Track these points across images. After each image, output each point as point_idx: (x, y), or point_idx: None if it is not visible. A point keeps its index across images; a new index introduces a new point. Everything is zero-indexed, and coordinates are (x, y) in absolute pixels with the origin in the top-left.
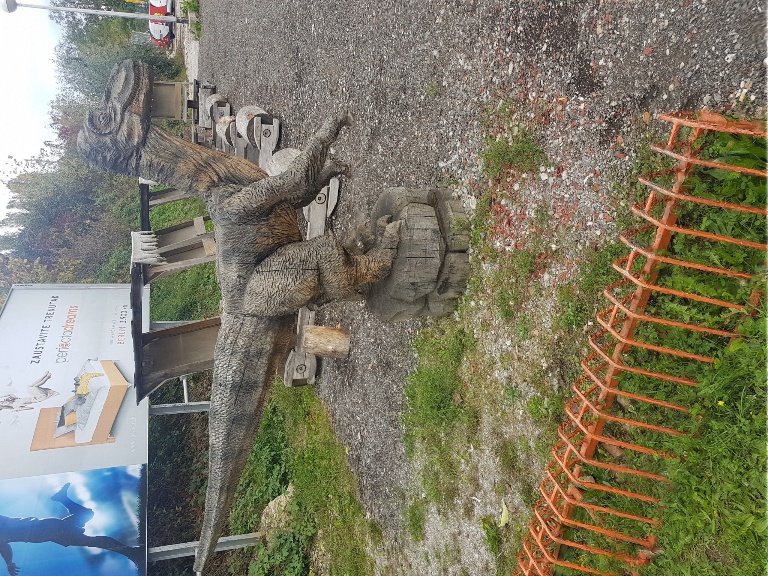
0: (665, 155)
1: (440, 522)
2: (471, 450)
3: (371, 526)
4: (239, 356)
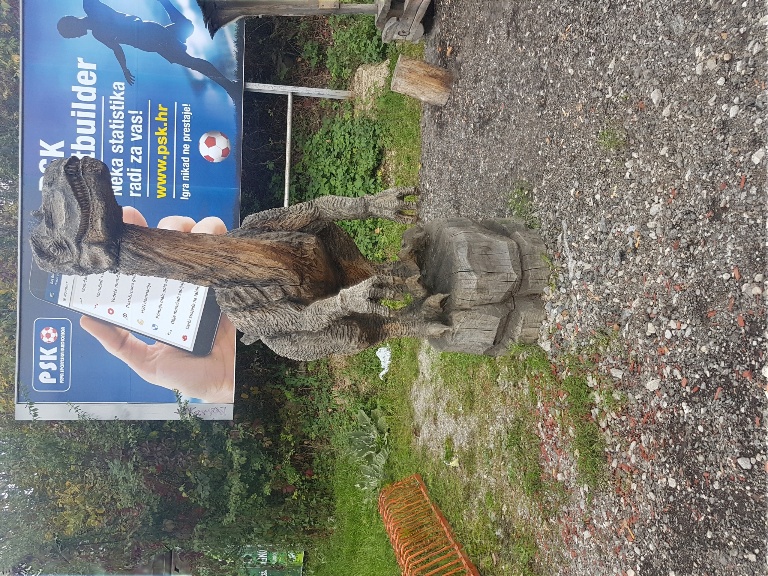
0: None
1: None
2: (459, 410)
3: None
4: None
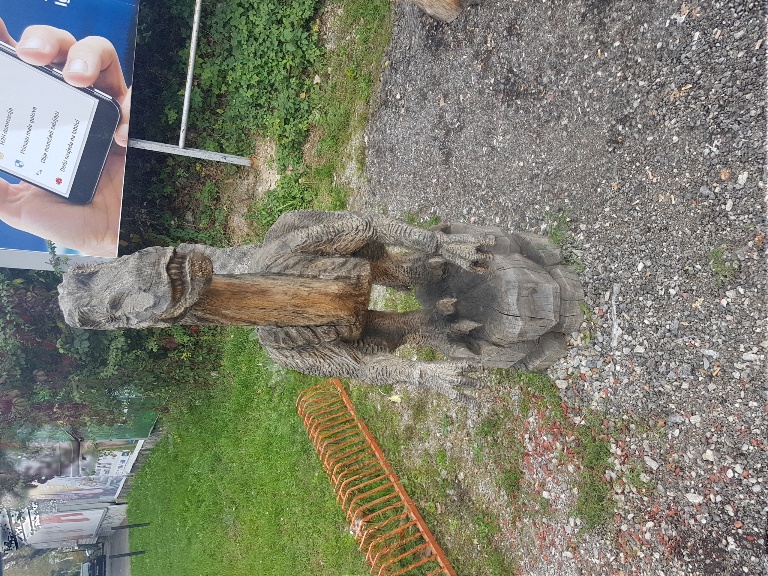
0: None
1: None
2: (413, 359)
3: None
4: None
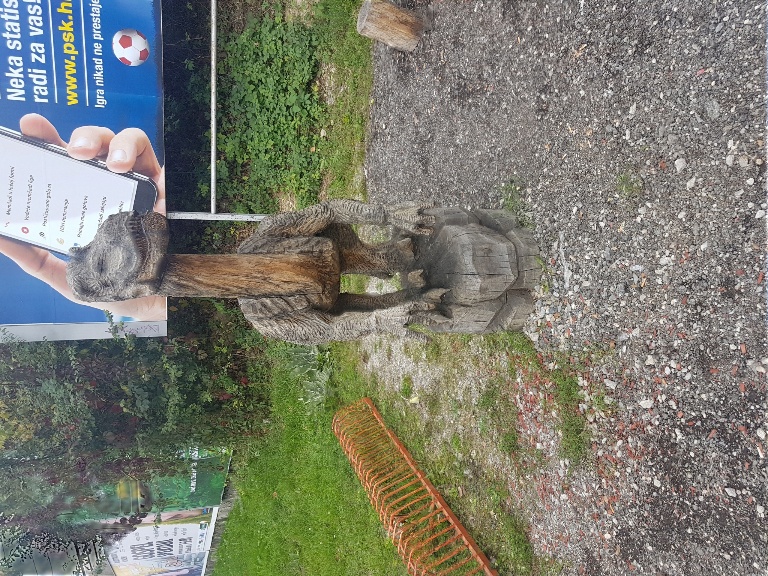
0: None
1: None
2: (423, 357)
3: None
4: None
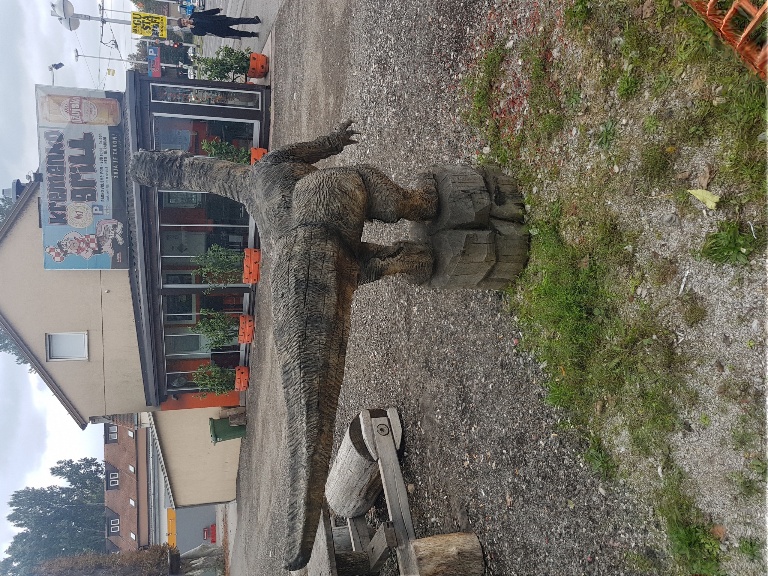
0: None
1: (700, 436)
2: (629, 247)
3: None
4: (299, 257)
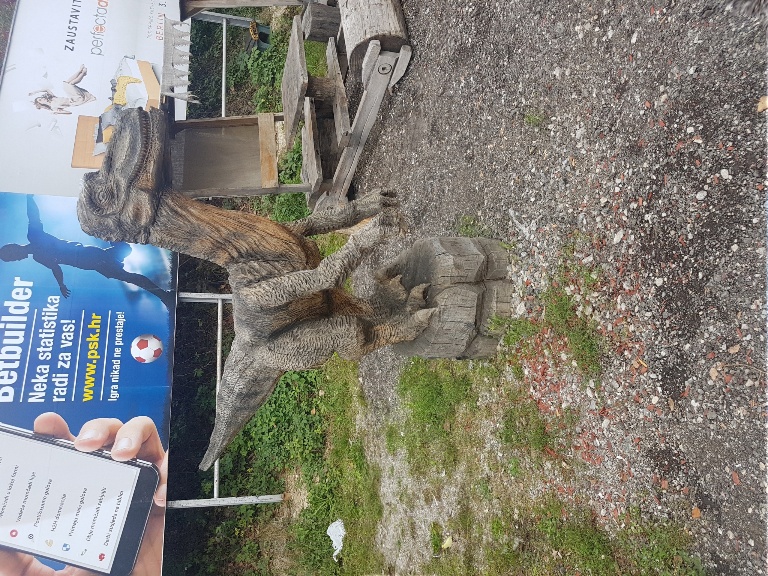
0: (684, 573)
1: (408, 468)
2: (442, 475)
3: (360, 396)
4: (247, 381)
